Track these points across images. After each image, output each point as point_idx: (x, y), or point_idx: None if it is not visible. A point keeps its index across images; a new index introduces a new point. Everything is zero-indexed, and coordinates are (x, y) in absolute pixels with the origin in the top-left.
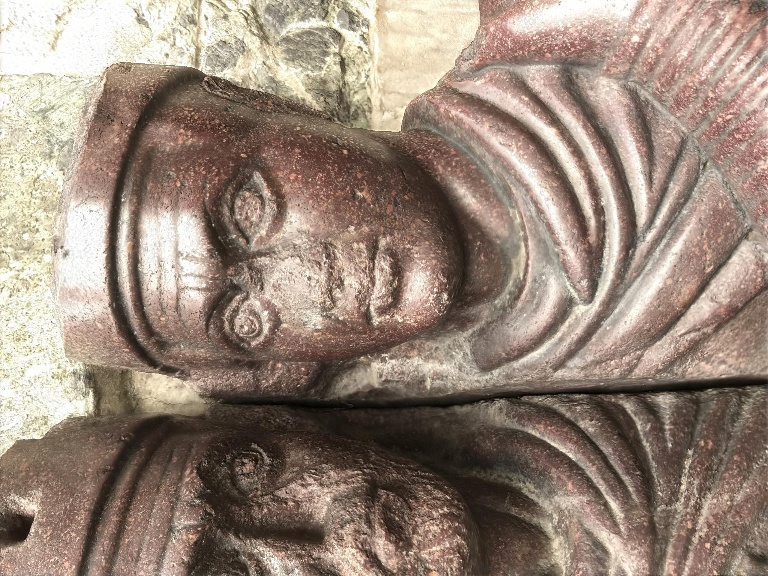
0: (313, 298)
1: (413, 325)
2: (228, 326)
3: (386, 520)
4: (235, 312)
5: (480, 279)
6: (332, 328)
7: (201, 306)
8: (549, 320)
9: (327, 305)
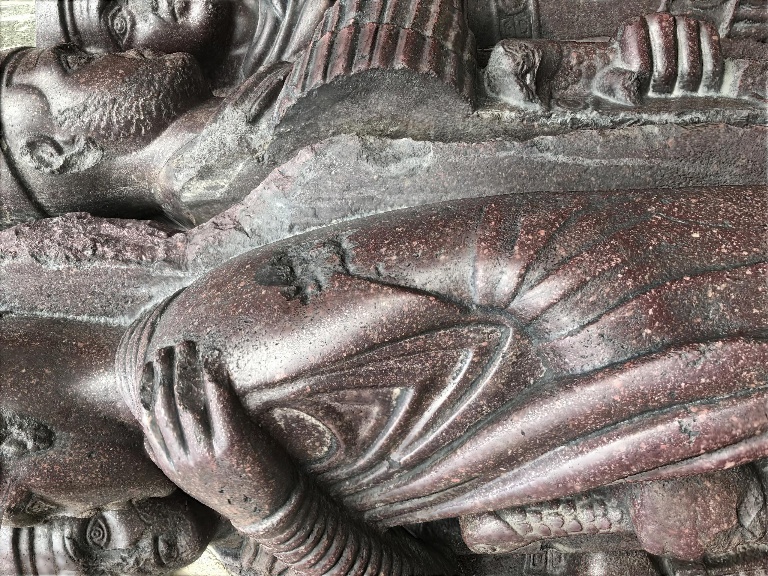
0: (147, 1)
1: (198, 25)
2: (111, 23)
3: (153, 50)
4: (115, 16)
5: (242, 24)
6: (158, 22)
7: (97, 4)
8: (268, 30)
9: (154, 5)
